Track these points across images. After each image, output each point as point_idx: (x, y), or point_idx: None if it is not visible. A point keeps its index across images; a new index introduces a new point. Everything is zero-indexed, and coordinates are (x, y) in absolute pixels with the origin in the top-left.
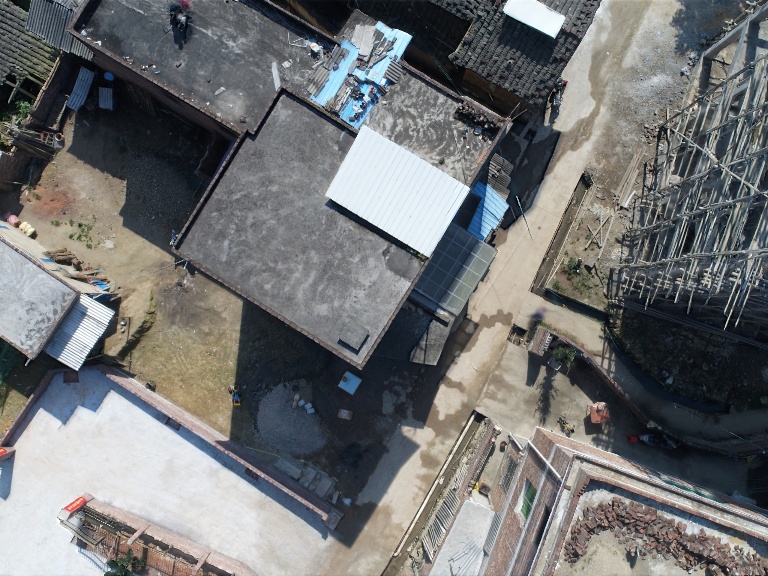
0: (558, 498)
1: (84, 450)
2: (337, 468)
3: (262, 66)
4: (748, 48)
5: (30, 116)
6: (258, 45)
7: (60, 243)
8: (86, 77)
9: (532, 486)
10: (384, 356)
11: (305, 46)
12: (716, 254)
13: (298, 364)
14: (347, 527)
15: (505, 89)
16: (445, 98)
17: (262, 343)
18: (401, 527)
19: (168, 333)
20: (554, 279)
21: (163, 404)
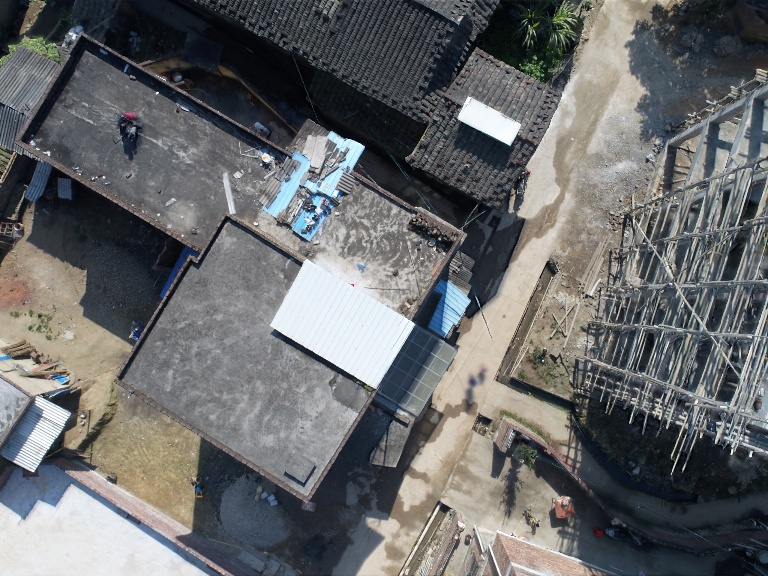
0: None
1: (44, 545)
2: (301, 560)
3: (213, 177)
4: (708, 149)
5: None
6: (209, 155)
7: (19, 335)
8: (44, 169)
9: None
10: None
11: (256, 157)
12: (667, 386)
13: None
14: None
15: (462, 191)
16: (399, 209)
17: None
18: None
19: (129, 424)
20: (519, 368)
21: (124, 498)
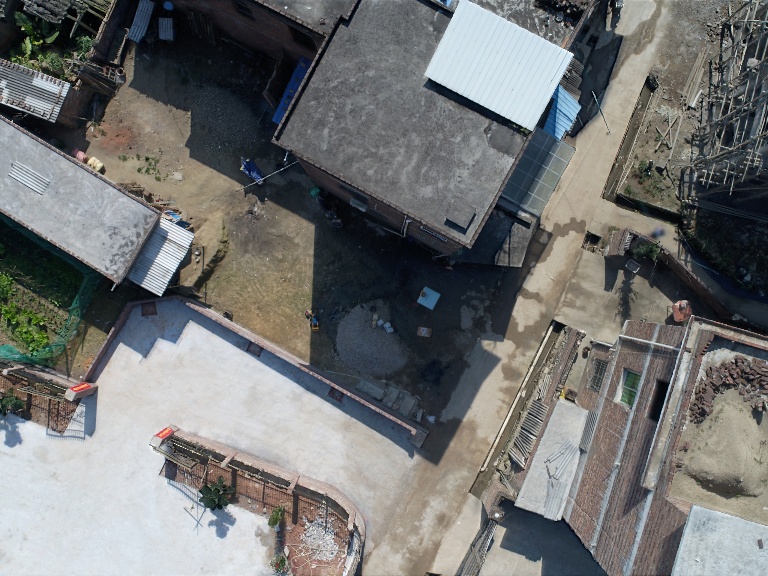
0: (679, 361)
1: (166, 382)
2: (419, 386)
3: None
4: None
5: (93, 49)
6: None
7: (129, 177)
8: (146, 7)
9: (631, 374)
10: (468, 261)
11: None
12: None
13: (374, 285)
14: (433, 444)
15: None
16: None
17: (336, 266)
18: (487, 441)
19: (242, 262)
20: (625, 184)
21: (243, 331)
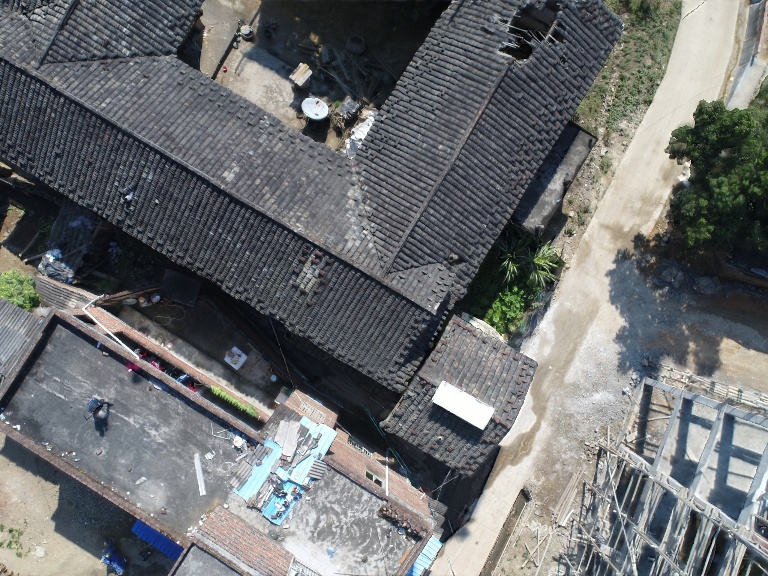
0: None
1: None
2: None
3: (184, 457)
4: (681, 424)
5: None
6: (181, 435)
7: None
8: None
9: None
10: None
11: (228, 439)
12: None
13: None
14: None
15: None
16: (369, 495)
17: None
18: None
19: None
20: None
21: None
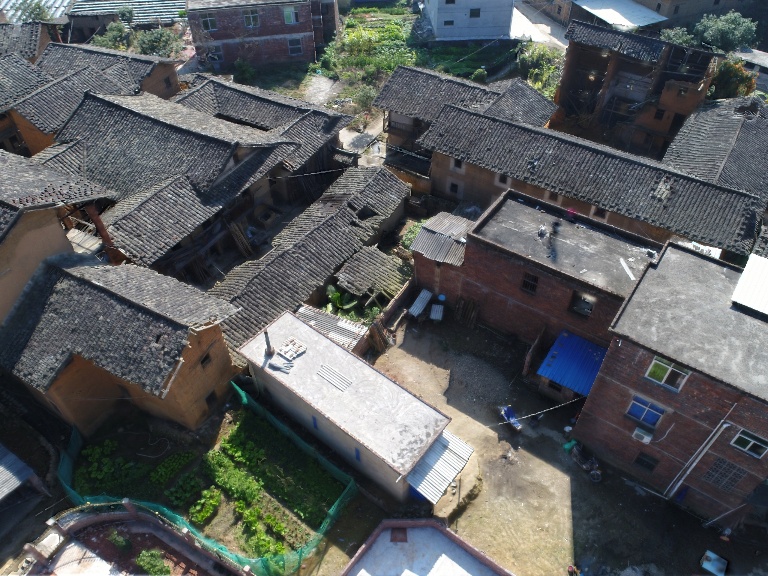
0: None
1: None
2: None
3: (612, 260)
4: None
5: (383, 314)
6: (606, 249)
7: None
8: (426, 296)
9: None
10: (767, 507)
11: (642, 251)
12: None
13: (642, 547)
14: None
15: None
16: None
17: (597, 521)
18: None
19: (495, 504)
20: None
21: None
